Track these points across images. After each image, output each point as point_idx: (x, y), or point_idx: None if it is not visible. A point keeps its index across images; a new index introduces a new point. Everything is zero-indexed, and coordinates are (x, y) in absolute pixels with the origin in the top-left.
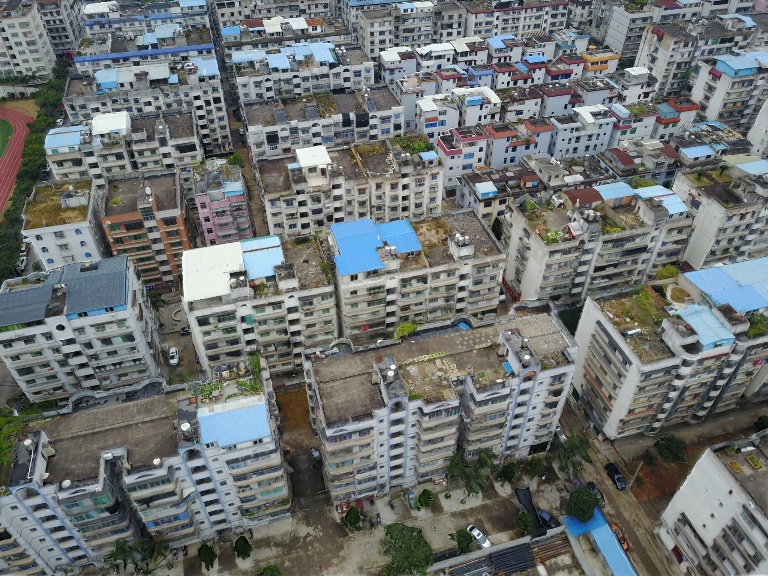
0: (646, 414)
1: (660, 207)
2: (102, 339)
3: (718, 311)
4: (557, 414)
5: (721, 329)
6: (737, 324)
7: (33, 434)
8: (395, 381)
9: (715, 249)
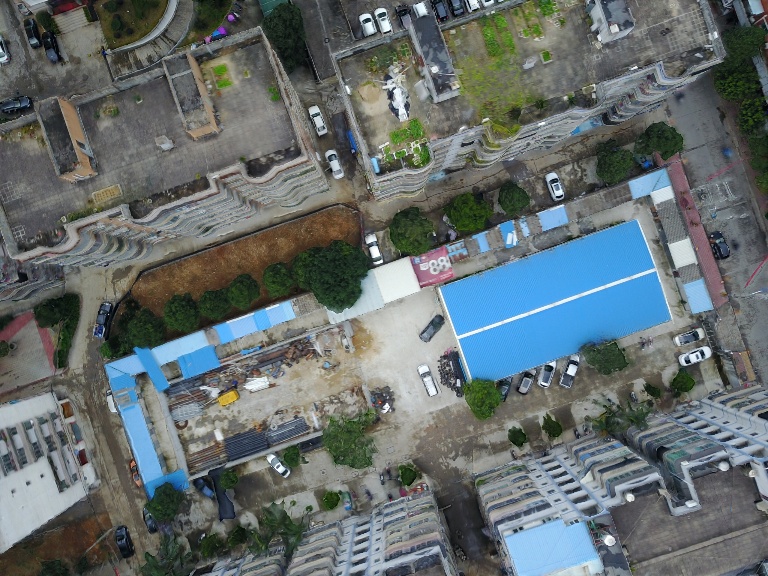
0: None
1: None
2: None
3: None
4: None
5: None
6: None
7: None
8: None
9: None
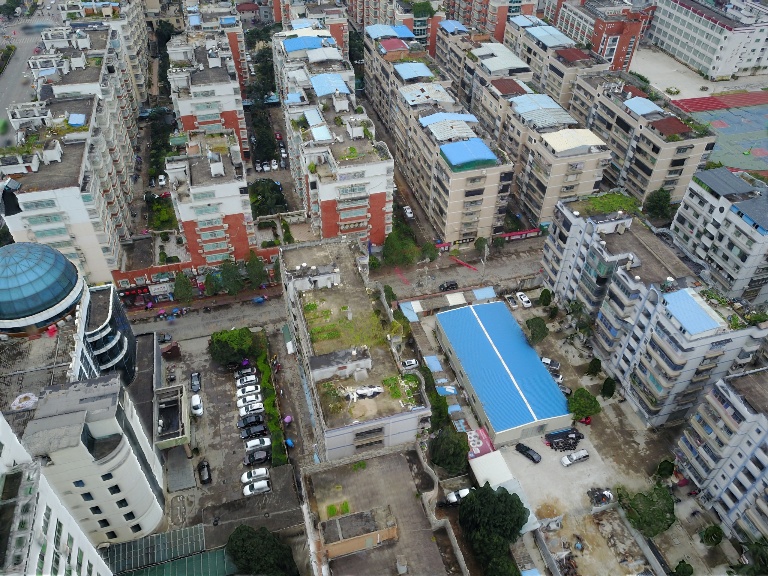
0: None
1: None
2: (731, 242)
3: None
4: None
5: None
6: None
7: (628, 216)
8: None
9: None
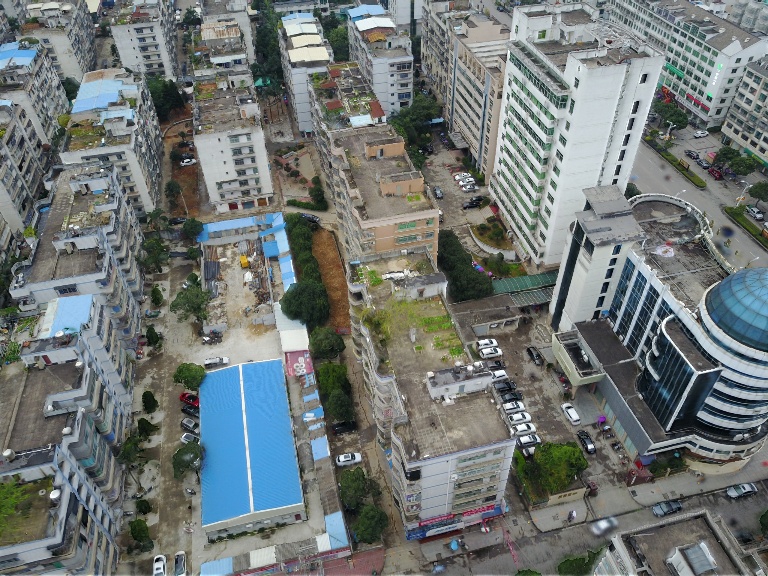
0: (150, 183)
1: (0, 107)
2: None
3: (111, 107)
4: (132, 210)
5: None
6: (125, 104)
7: None
8: (82, 231)
9: (42, 121)
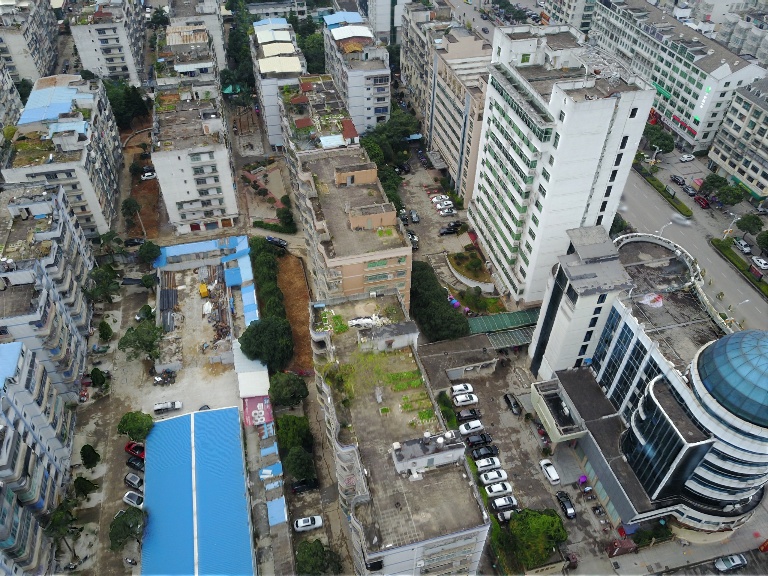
0: (104, 201)
1: None
2: None
3: (62, 119)
4: (82, 233)
5: (76, 123)
6: (78, 115)
7: None
8: (16, 265)
9: None
